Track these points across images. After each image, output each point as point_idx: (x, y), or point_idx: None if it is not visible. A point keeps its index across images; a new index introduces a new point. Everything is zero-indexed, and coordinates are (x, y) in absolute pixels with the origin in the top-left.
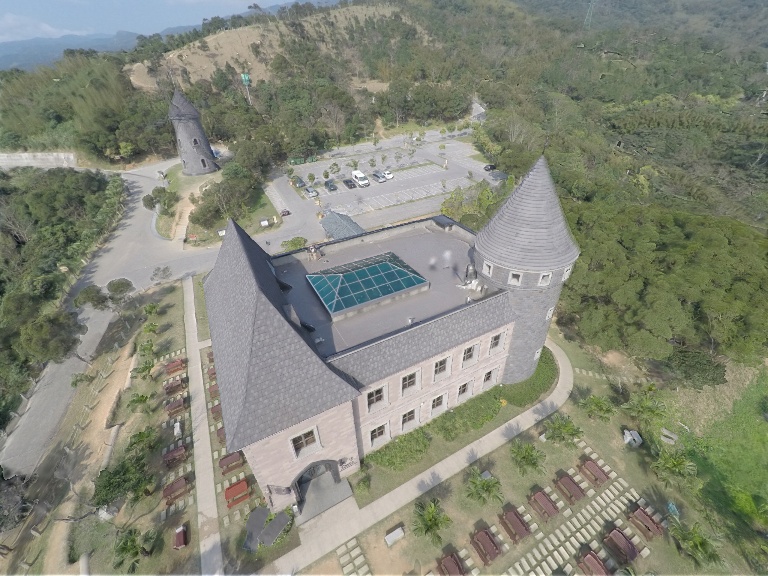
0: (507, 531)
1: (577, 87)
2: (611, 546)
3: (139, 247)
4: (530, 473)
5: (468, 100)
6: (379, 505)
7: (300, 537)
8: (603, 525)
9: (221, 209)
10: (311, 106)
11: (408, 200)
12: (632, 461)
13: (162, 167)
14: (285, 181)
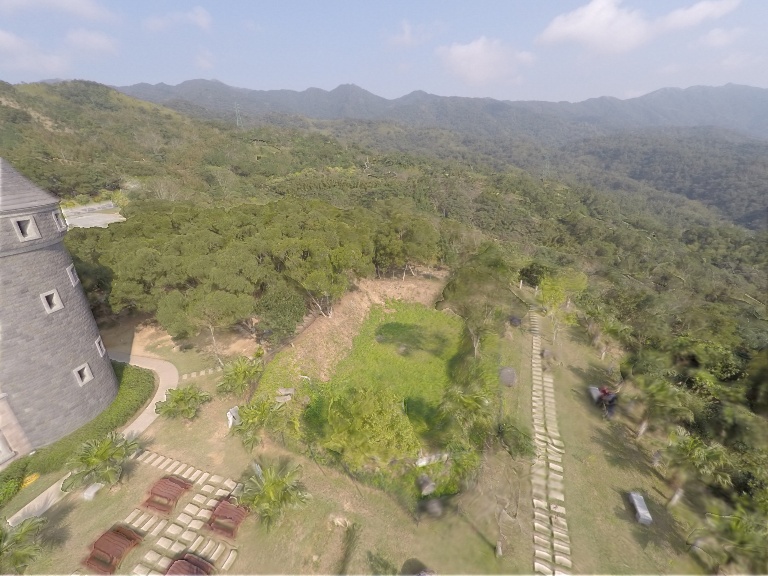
0: None
1: (239, 166)
2: None
3: None
4: (40, 572)
5: (112, 176)
6: None
7: None
8: (168, 567)
9: None
10: None
11: None
12: (234, 444)
13: None
14: None
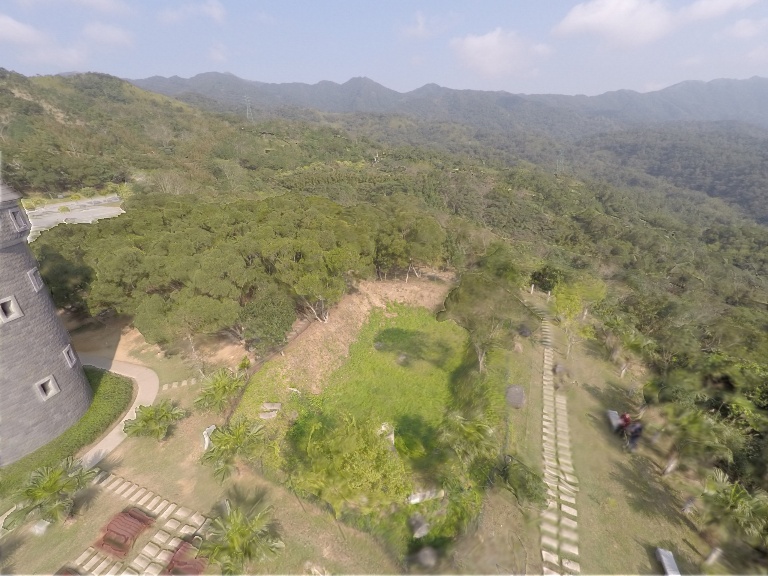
0: None
1: (247, 159)
2: None
3: None
4: None
5: (120, 169)
6: None
7: None
8: None
9: None
10: None
11: None
12: (208, 470)
13: None
14: None
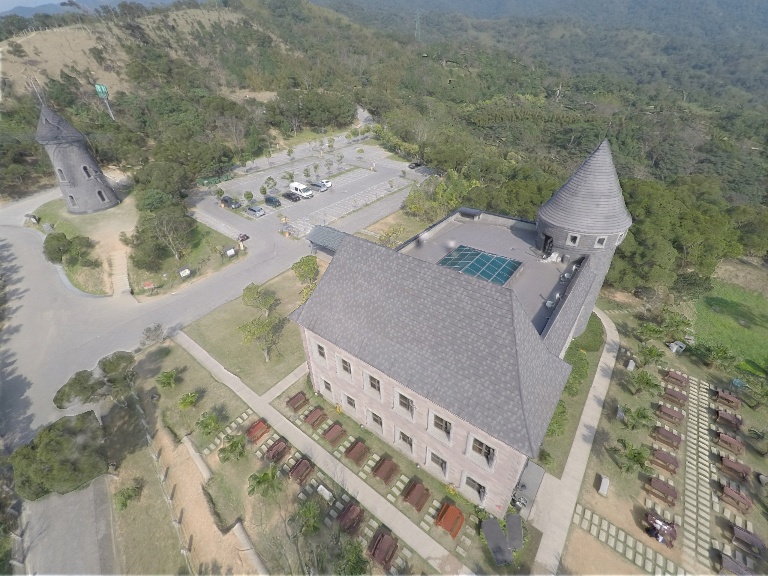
0: (666, 443)
1: (434, 91)
2: (724, 422)
3: (66, 314)
4: (642, 396)
5: (353, 106)
6: (571, 469)
7: (537, 527)
8: (707, 412)
9: (168, 245)
10: (199, 119)
11: (363, 204)
12: (686, 362)
13: (20, 210)
14: (212, 204)
